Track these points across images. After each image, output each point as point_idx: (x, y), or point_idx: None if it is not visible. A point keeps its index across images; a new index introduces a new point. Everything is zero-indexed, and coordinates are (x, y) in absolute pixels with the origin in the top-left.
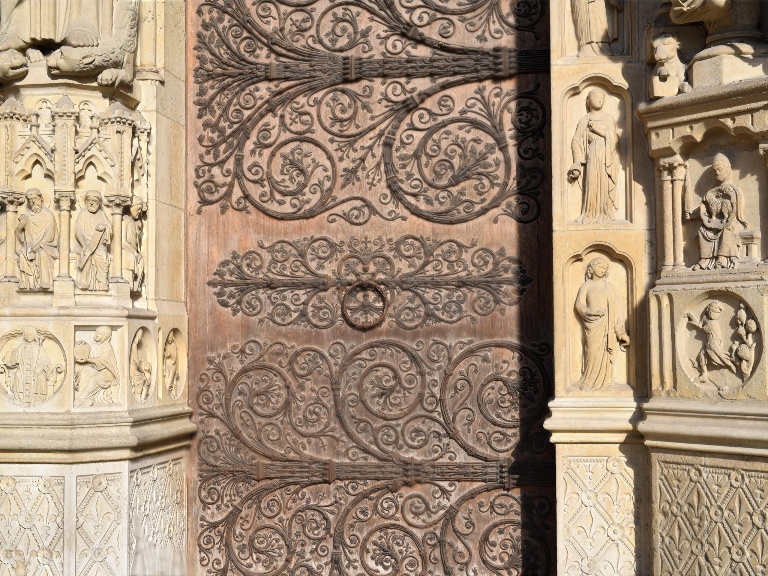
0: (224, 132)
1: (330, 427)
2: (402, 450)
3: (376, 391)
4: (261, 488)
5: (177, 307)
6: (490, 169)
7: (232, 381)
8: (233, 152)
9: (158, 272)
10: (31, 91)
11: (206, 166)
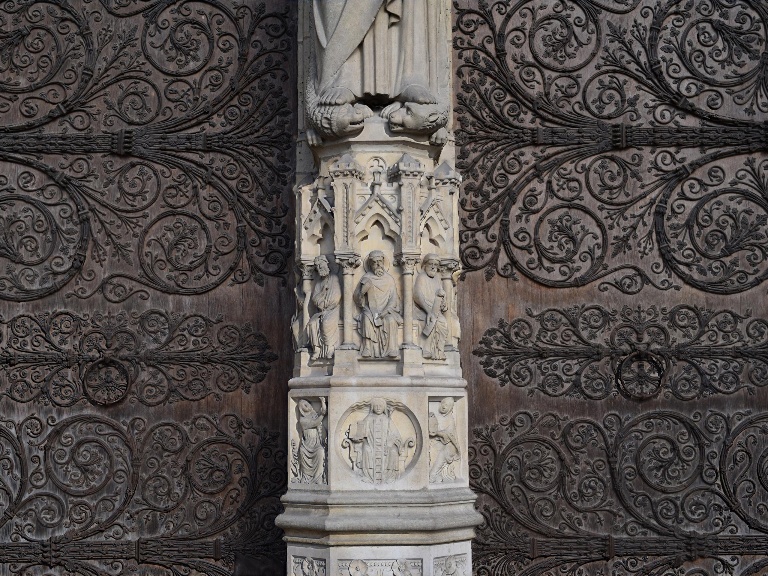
0: (488, 196)
1: (607, 501)
2: (682, 524)
3: (654, 464)
4: (536, 567)
5: None
6: (762, 240)
7: (502, 454)
8: (498, 217)
9: None
10: (363, 148)
11: (469, 231)
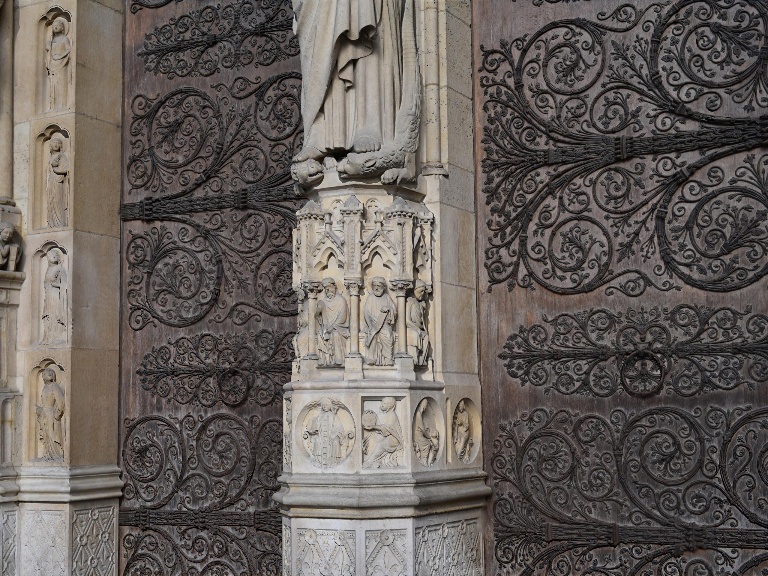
0: (509, 216)
1: (614, 492)
2: (684, 516)
3: (656, 457)
4: (551, 549)
5: (469, 379)
6: (762, 236)
7: (522, 447)
8: (518, 234)
9: (446, 347)
10: (327, 193)
11: (494, 248)
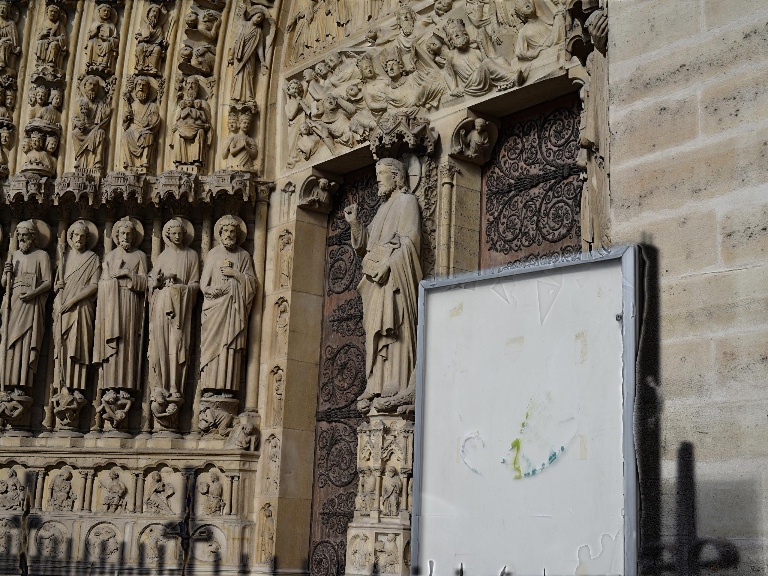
0: None
1: None
2: None
3: None
4: None
5: None
6: None
7: None
8: None
9: None
10: (373, 418)
11: None
